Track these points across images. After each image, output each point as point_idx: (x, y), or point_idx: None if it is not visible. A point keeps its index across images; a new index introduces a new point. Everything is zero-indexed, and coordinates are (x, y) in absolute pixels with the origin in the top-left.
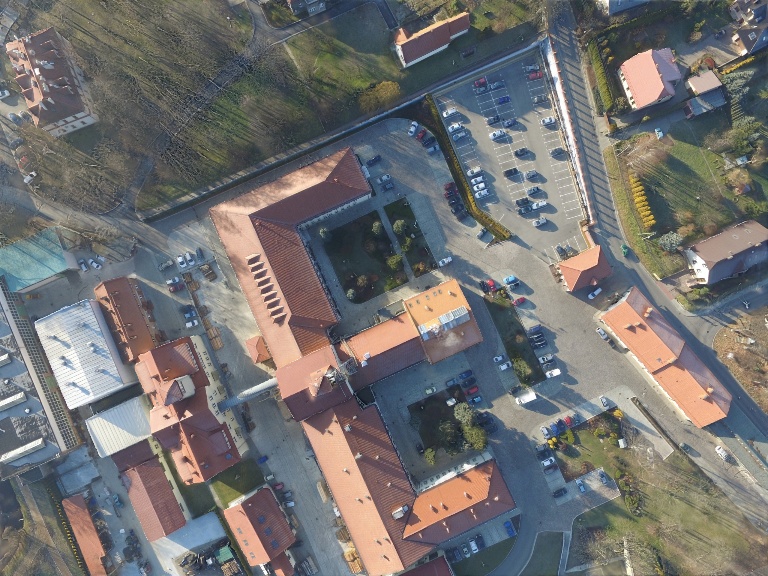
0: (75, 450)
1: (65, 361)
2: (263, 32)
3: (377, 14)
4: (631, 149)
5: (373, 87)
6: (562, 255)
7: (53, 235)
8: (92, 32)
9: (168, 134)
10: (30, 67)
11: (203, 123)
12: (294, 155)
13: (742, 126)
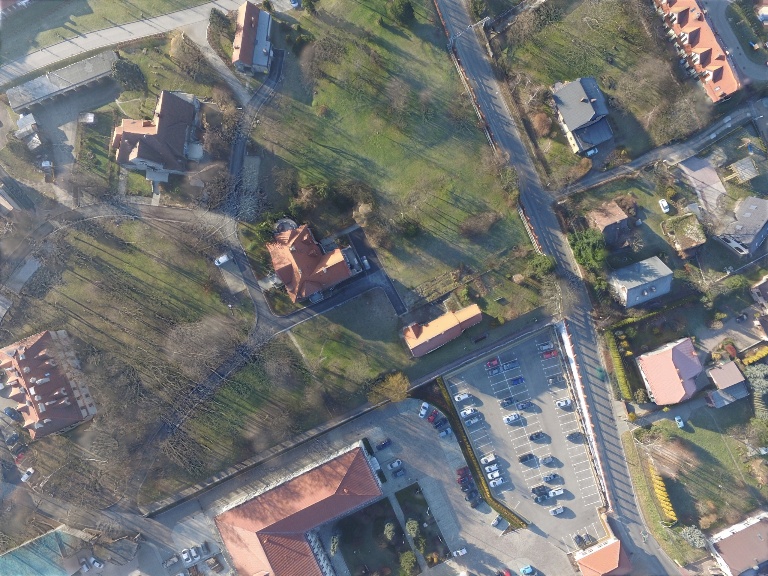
0: None
1: None
2: (266, 321)
3: (385, 300)
4: (651, 443)
5: (382, 379)
6: (580, 545)
7: (53, 543)
8: (88, 320)
9: (170, 426)
10: (25, 386)
11: (206, 414)
12: (301, 442)
13: (766, 420)
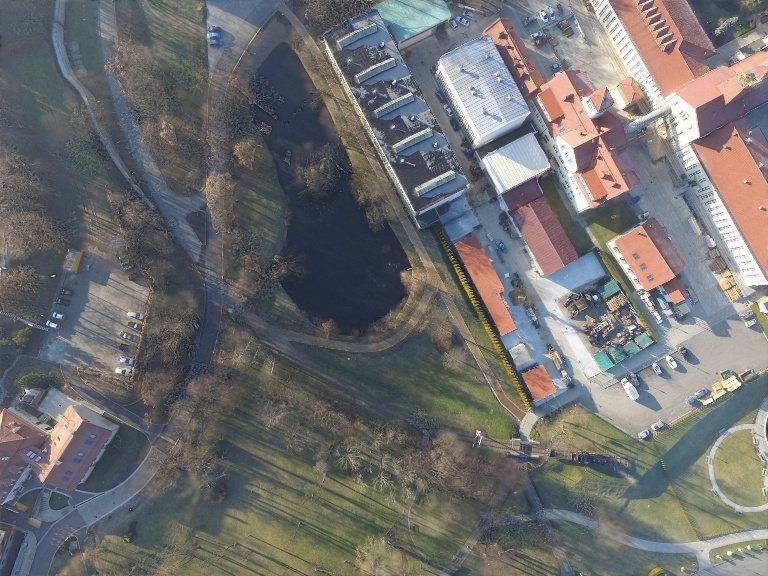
0: (456, 200)
1: None
2: None
3: None
4: None
5: None
6: None
7: None
8: None
9: None
10: None
11: None
12: None
13: None
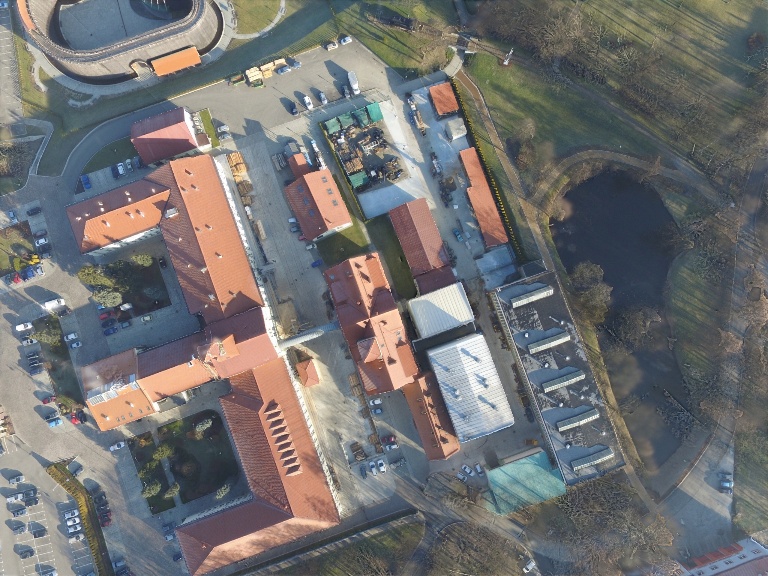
0: None
1: (485, 383)
2: None
3: None
4: None
5: None
6: None
7: (503, 507)
8: None
9: None
10: None
11: None
12: (261, 569)
13: None
